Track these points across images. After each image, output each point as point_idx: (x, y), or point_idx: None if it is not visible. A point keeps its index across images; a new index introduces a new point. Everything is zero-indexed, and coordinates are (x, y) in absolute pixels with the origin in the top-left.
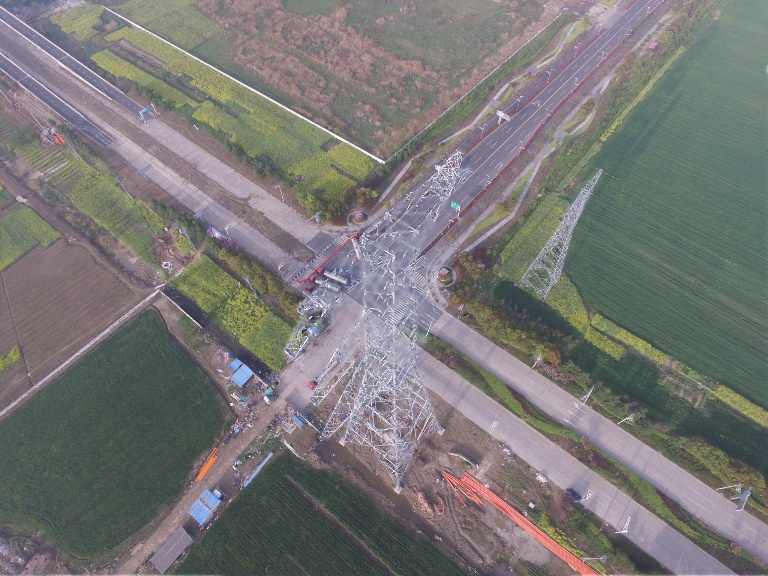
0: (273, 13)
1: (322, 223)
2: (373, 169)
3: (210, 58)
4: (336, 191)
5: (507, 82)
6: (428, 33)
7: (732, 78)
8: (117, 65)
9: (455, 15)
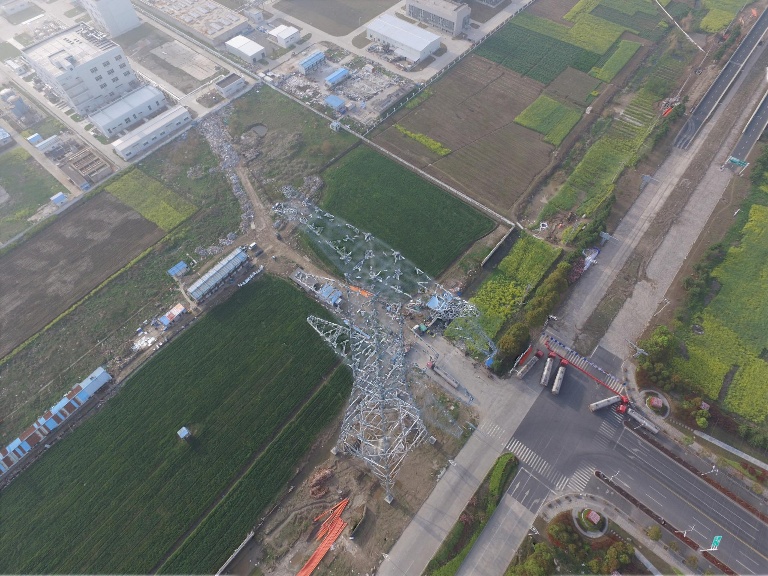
0: None
1: (635, 360)
2: (752, 421)
3: None
4: (691, 373)
5: None
6: None
7: None
8: None
9: None
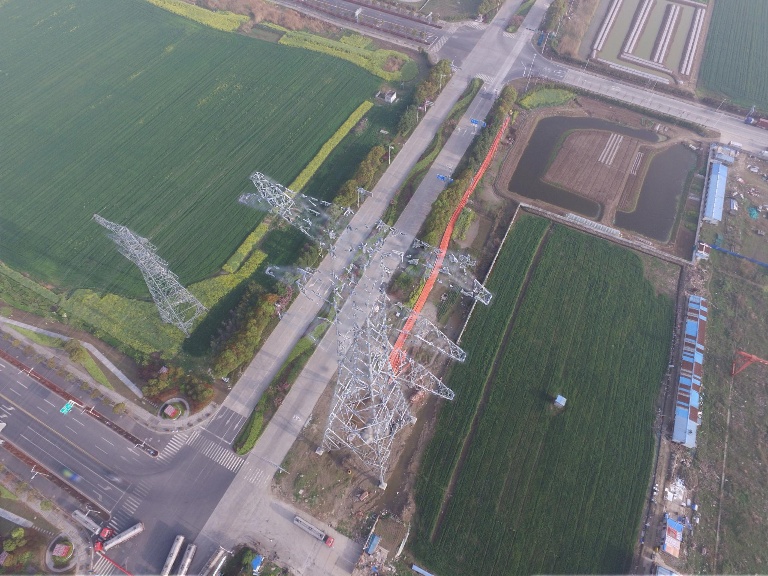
0: None
1: None
2: None
3: None
4: None
5: None
6: None
7: None
8: None
9: None
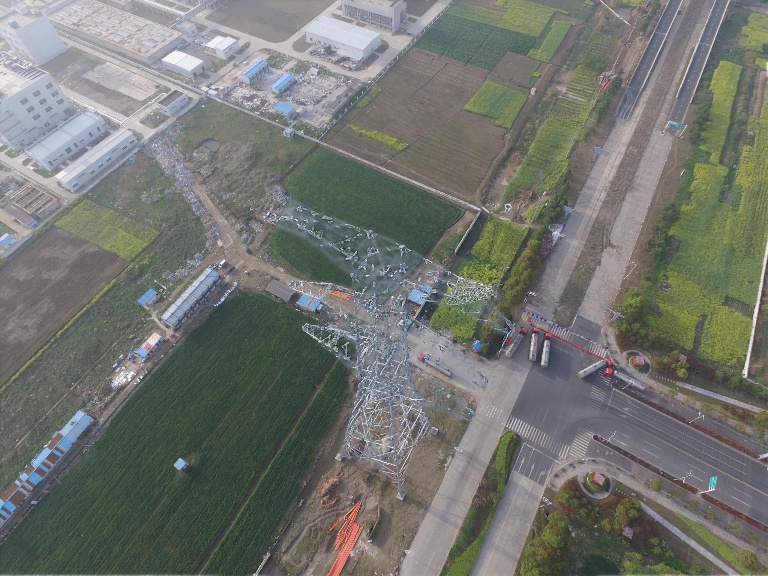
0: None
1: (613, 324)
2: (726, 365)
3: None
4: (666, 328)
5: None
6: None
7: None
8: (725, 82)
9: None
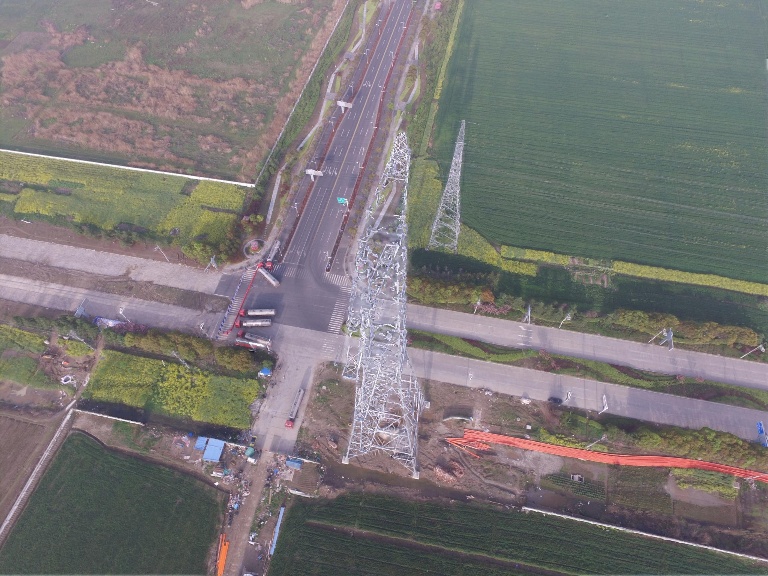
0: (56, 74)
1: (220, 266)
2: (246, 195)
3: (3, 143)
4: (219, 230)
5: (332, 73)
6: (235, 49)
7: (509, 16)
8: None
9: (253, 25)
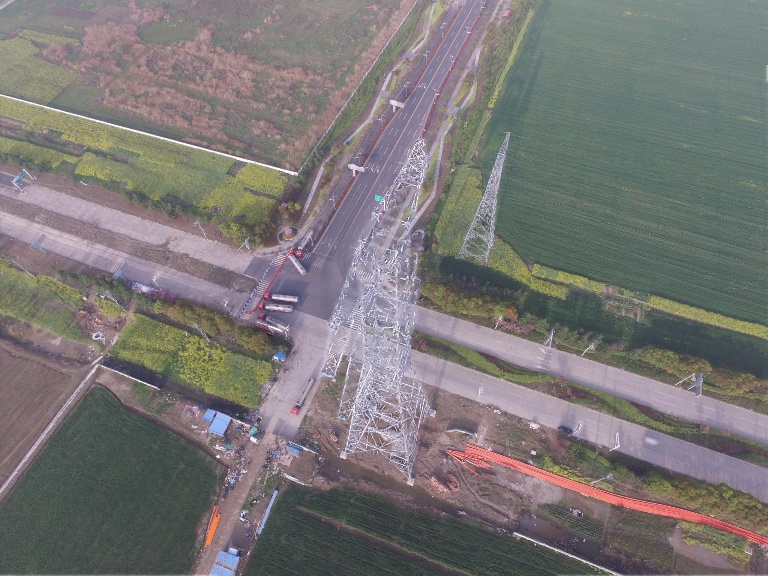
0: (131, 47)
1: (253, 248)
2: (288, 183)
3: (75, 107)
4: (257, 213)
5: (389, 72)
6: (299, 39)
7: (579, 30)
8: None
9: (320, 17)
